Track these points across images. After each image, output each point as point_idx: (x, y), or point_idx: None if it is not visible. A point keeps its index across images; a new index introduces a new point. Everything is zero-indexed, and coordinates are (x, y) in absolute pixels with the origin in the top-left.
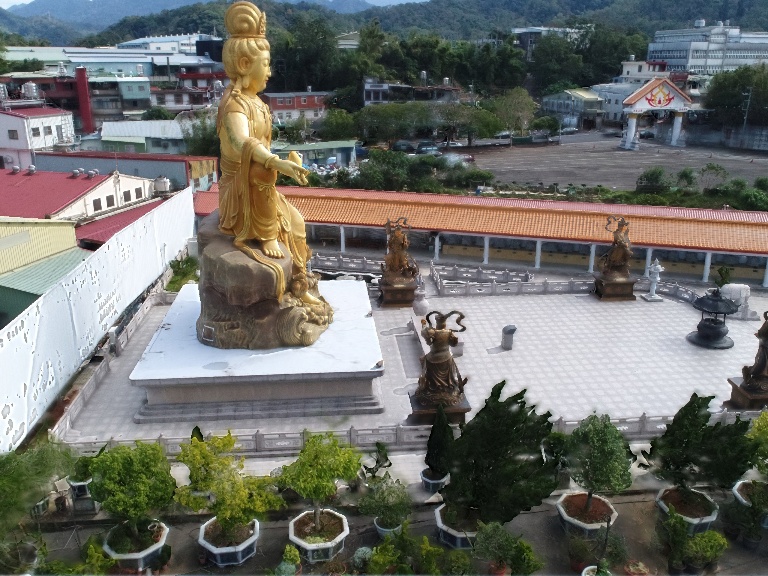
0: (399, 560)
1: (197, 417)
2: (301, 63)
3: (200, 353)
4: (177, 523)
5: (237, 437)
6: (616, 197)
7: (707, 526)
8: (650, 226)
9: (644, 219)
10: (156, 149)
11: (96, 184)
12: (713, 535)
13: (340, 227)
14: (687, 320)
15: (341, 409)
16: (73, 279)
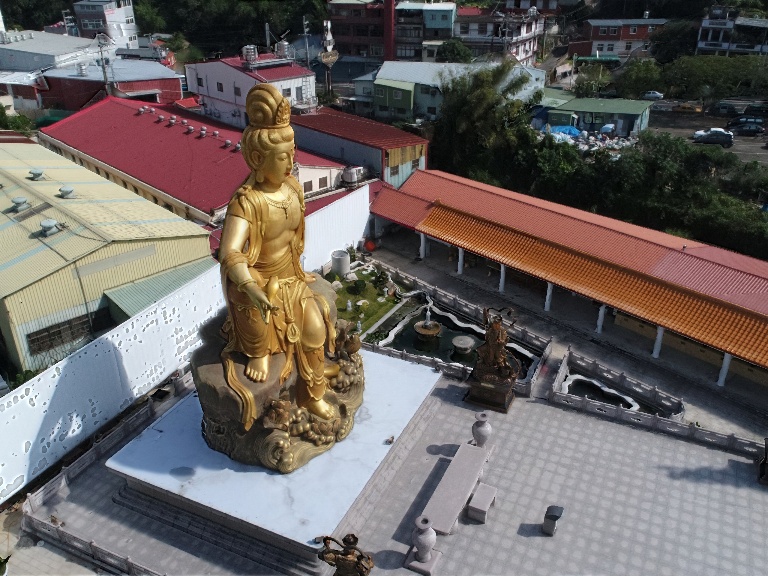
0: None
1: (158, 517)
2: None
3: (188, 446)
4: None
5: (149, 571)
6: None
7: None
8: None
9: None
10: (424, 96)
11: None
12: None
13: (500, 264)
14: None
15: (280, 565)
16: (128, 327)
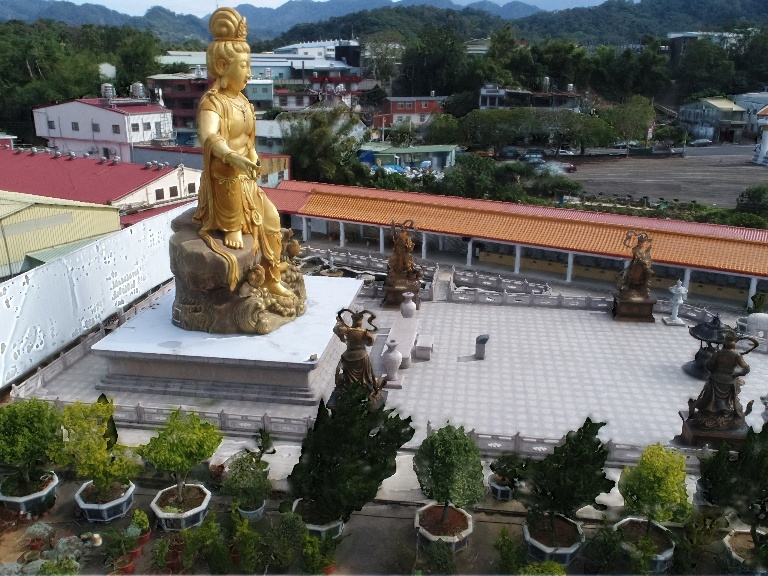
0: (224, 538)
1: (147, 389)
2: (428, 68)
3: (165, 332)
4: (79, 479)
5: (162, 410)
6: (711, 214)
7: (566, 558)
8: (691, 245)
9: (686, 237)
10: (262, 147)
11: (160, 175)
12: (550, 566)
13: (379, 228)
14: (698, 348)
15: (276, 397)
16: None
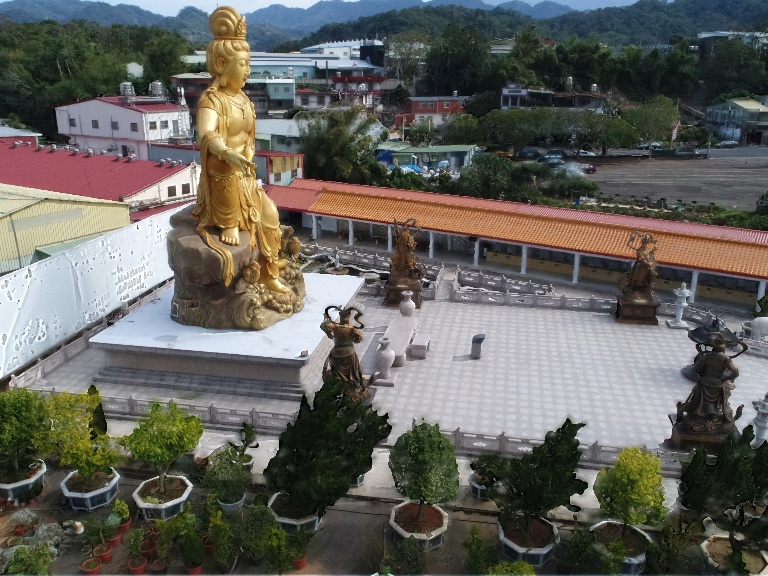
0: (198, 529)
1: (143, 382)
2: (451, 68)
3: (163, 326)
4: (68, 468)
5: None
6: (729, 217)
7: (539, 558)
8: (699, 247)
9: (695, 239)
10: (281, 146)
11: (173, 173)
12: (520, 566)
13: (388, 226)
14: None
15: (268, 392)
16: None
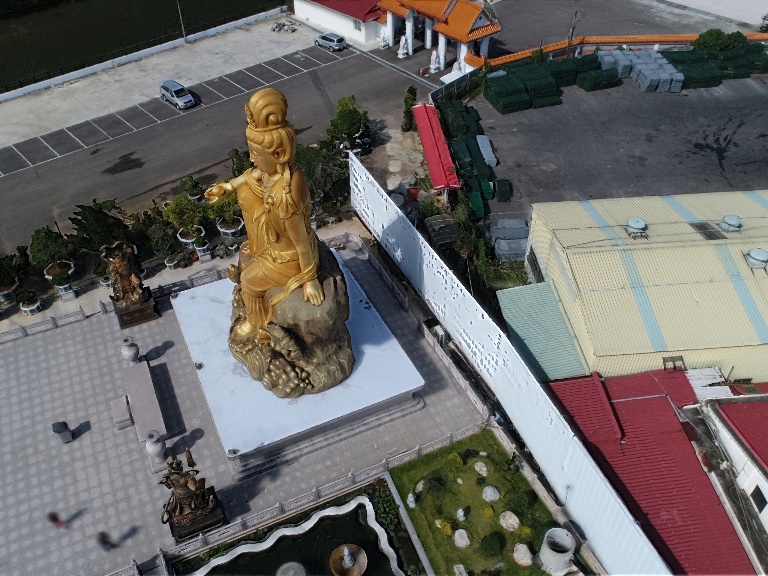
0: None
1: None
2: None
3: None
4: None
5: None
6: None
7: None
8: None
9: None
10: None
11: None
12: None
13: None
14: None
15: None
16: None
